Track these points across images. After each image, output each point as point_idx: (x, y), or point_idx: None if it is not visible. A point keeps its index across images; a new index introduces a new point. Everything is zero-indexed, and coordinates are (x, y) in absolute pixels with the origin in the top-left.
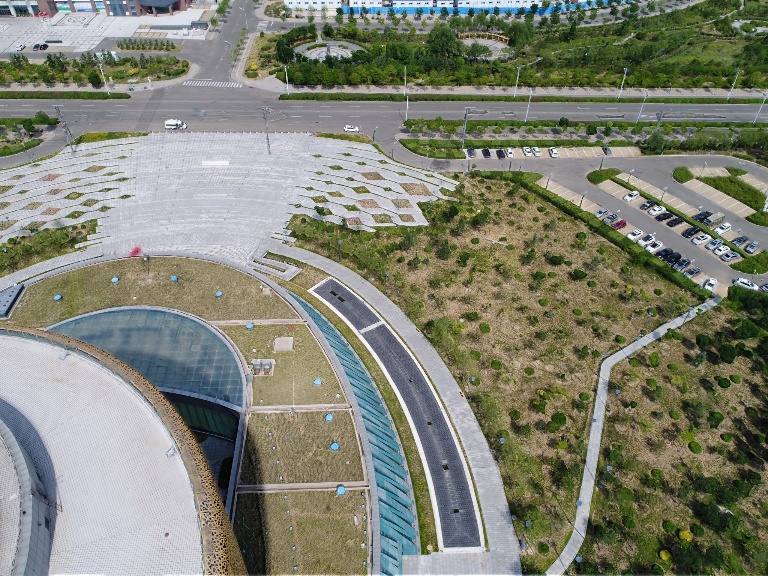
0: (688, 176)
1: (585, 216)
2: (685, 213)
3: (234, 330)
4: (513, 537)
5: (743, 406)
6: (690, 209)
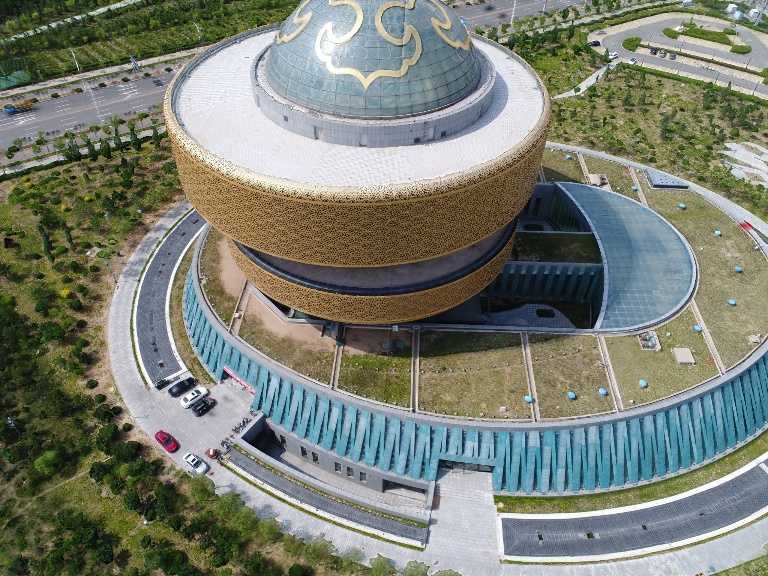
0: None
1: None
2: None
3: (689, 318)
4: None
5: None
6: None
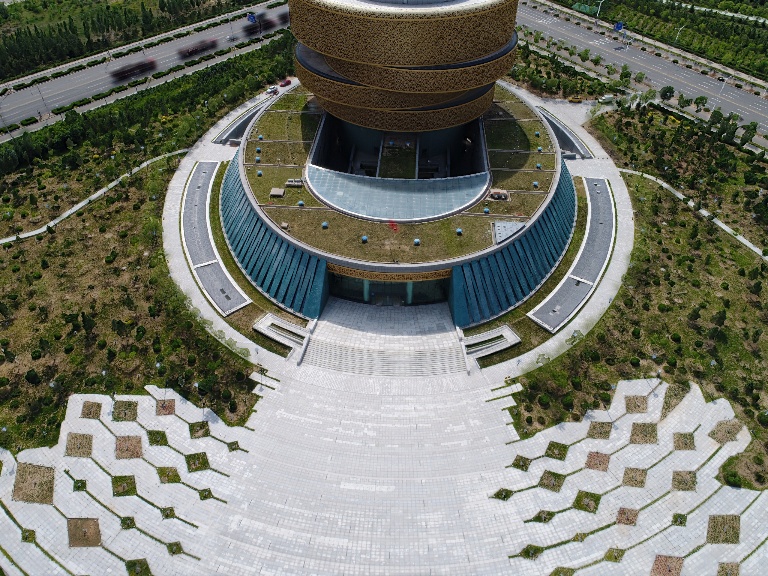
0: None
1: None
2: None
3: (313, 204)
4: None
5: None
6: None
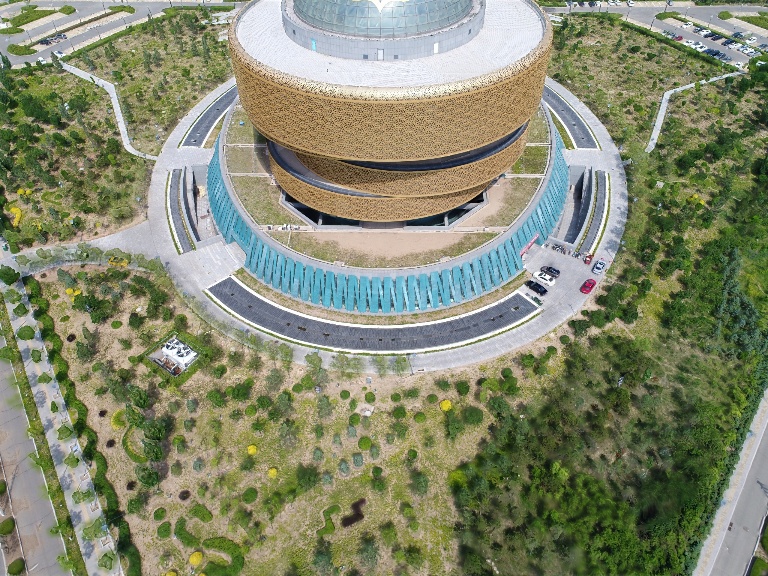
0: (729, 16)
1: (654, 34)
2: (725, 34)
3: None
4: (615, 147)
5: (751, 111)
6: (729, 32)
